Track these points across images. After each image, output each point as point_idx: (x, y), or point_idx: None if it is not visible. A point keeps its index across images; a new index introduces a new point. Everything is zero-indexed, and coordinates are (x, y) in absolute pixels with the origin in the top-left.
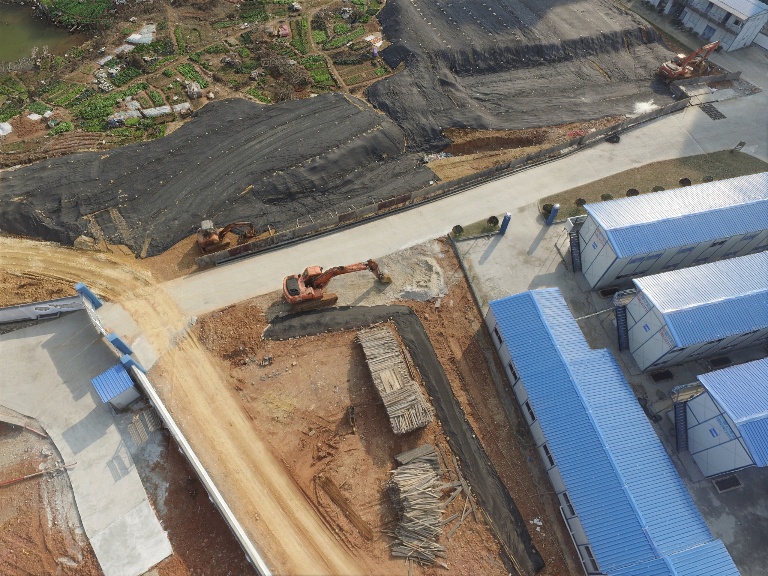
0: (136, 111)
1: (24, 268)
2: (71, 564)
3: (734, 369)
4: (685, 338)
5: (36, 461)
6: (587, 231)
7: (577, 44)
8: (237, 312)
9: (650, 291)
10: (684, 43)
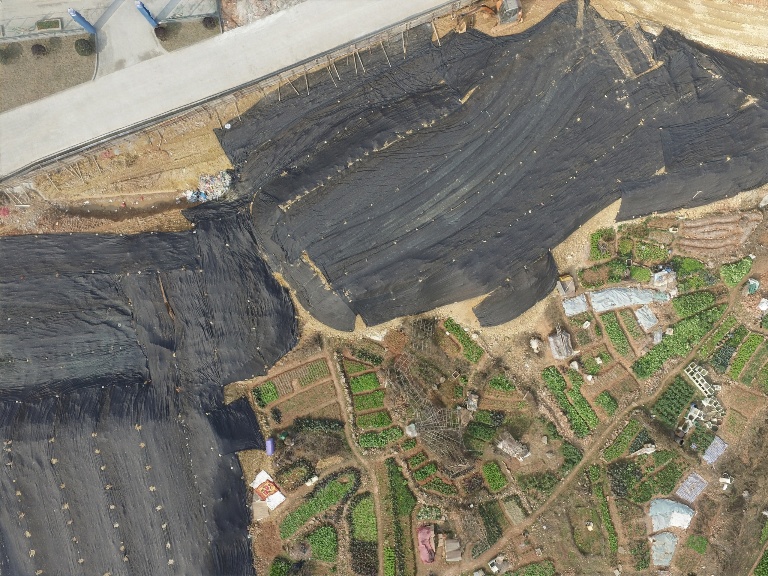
0: (640, 299)
1: (710, 3)
2: None
3: None
4: None
5: None
6: None
7: None
8: None
9: None
10: None
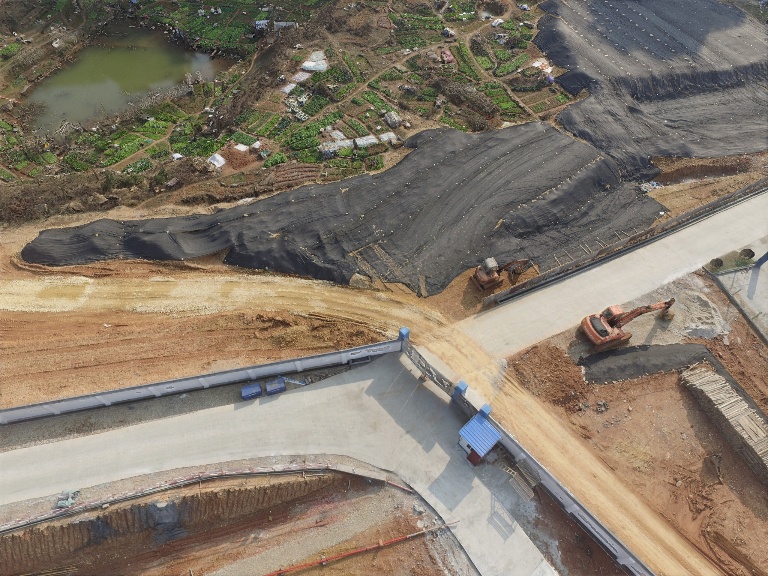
0: (344, 141)
1: (307, 309)
2: None
3: None
4: None
5: (412, 519)
6: None
7: (748, 70)
8: (542, 353)
9: None
10: None
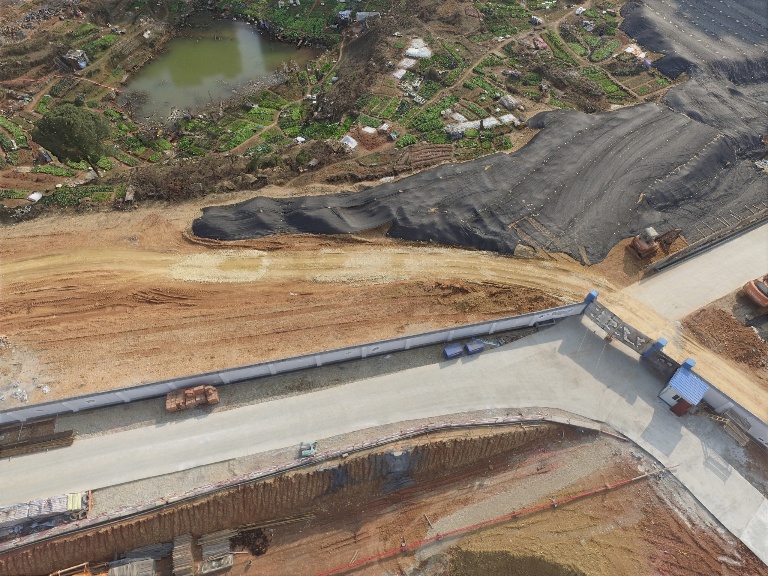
0: (468, 123)
1: (479, 277)
2: (733, 563)
3: None
4: None
5: (632, 464)
6: None
7: None
8: (712, 316)
9: None
10: None
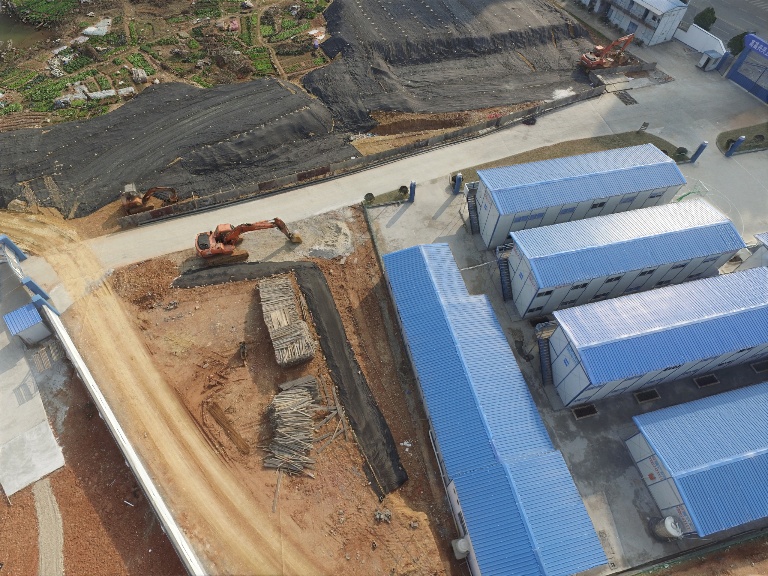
0: (82, 94)
1: None
2: None
3: (587, 306)
4: (547, 280)
5: None
6: (480, 194)
7: (506, 38)
8: (152, 265)
9: (523, 242)
10: (609, 38)
